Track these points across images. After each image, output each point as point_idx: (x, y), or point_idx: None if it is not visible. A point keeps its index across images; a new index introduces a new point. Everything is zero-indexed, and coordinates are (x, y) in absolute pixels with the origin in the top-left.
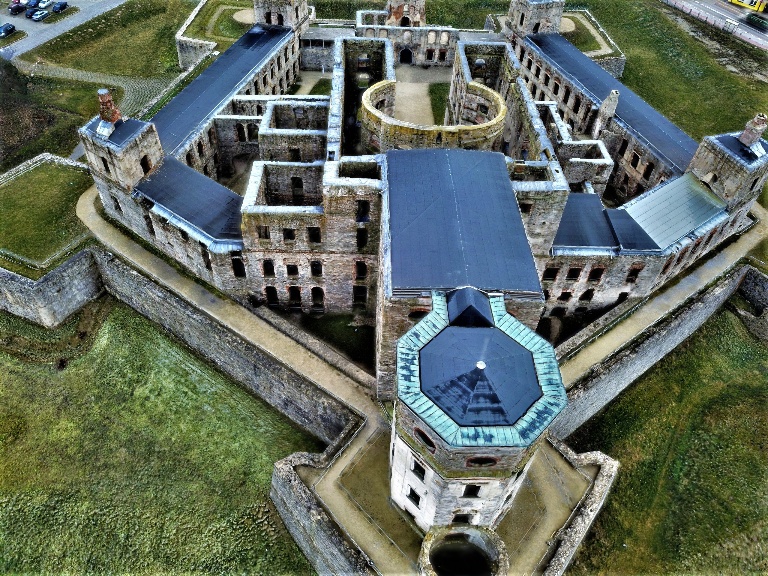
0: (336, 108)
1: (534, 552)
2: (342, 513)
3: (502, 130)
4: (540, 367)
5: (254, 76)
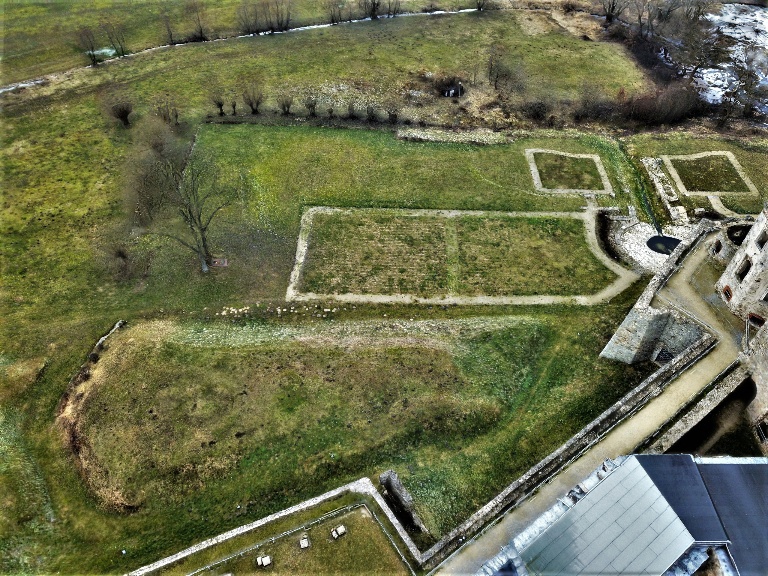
0: None
1: (690, 264)
2: None
3: None
4: None
5: None
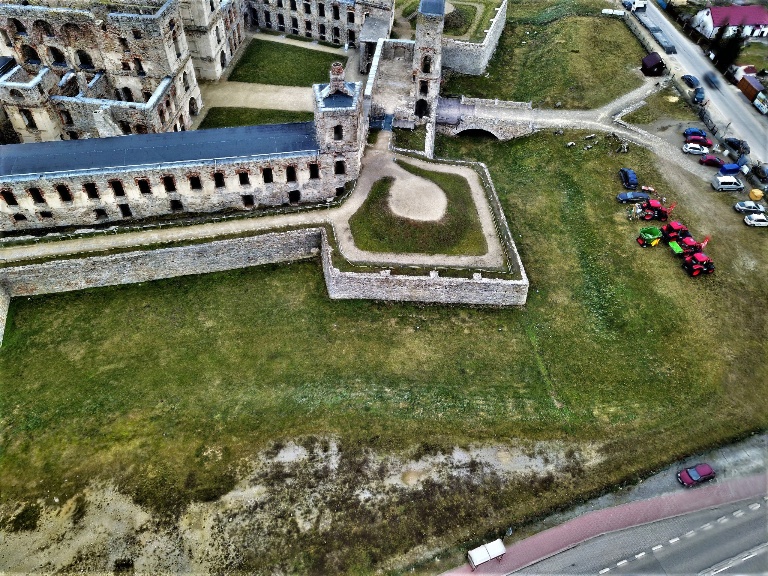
0: None
1: None
2: None
3: (34, 4)
4: None
5: None
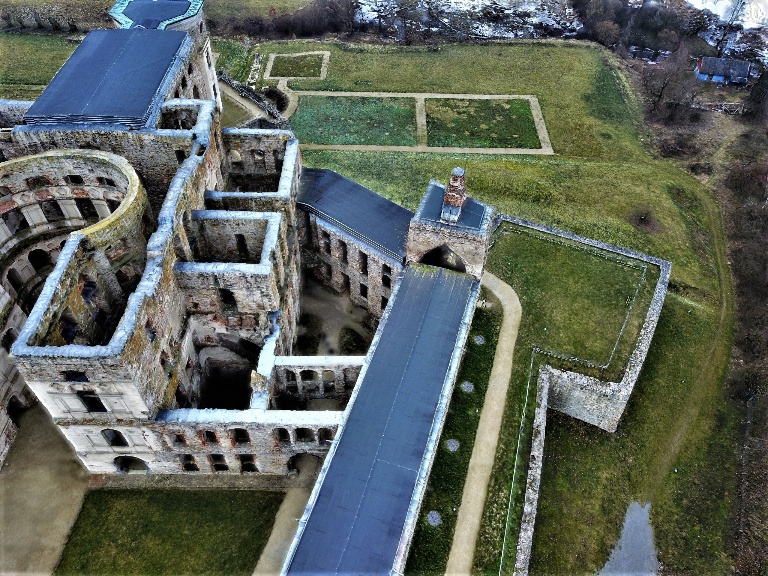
0: (176, 185)
1: None
2: (252, 108)
3: None
4: (122, 8)
5: (310, 502)
